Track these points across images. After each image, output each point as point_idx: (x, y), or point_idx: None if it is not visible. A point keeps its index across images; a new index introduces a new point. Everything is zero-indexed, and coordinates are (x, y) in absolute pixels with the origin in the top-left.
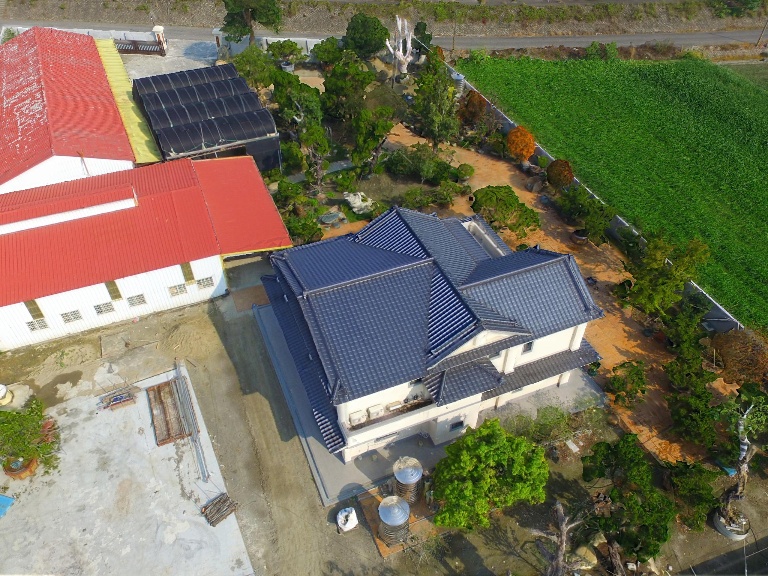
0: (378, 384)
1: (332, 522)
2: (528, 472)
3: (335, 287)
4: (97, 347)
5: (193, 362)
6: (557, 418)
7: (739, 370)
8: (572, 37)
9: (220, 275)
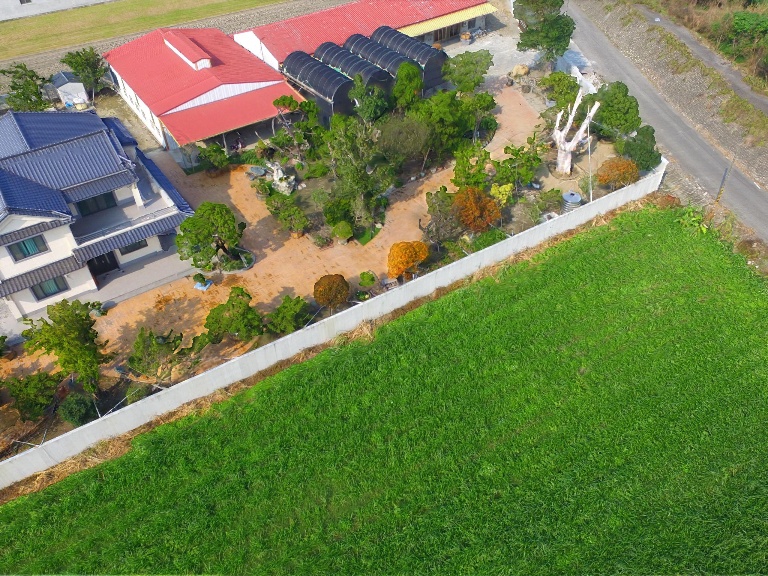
0: None
1: None
2: None
3: None
4: None
5: None
6: None
7: None
8: None
9: None
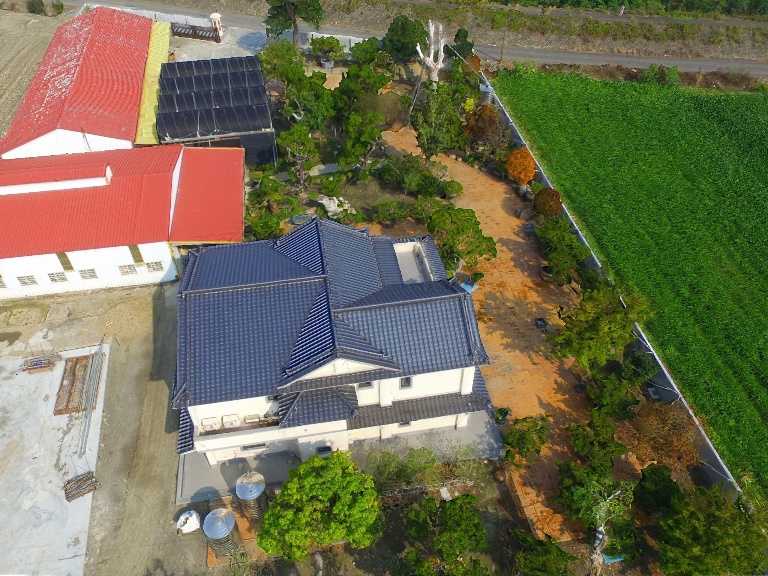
0: (223, 394)
1: (176, 521)
2: (348, 513)
3: (216, 290)
4: (45, 312)
5: (119, 341)
6: (427, 462)
7: (653, 448)
8: (636, 57)
9: (169, 261)
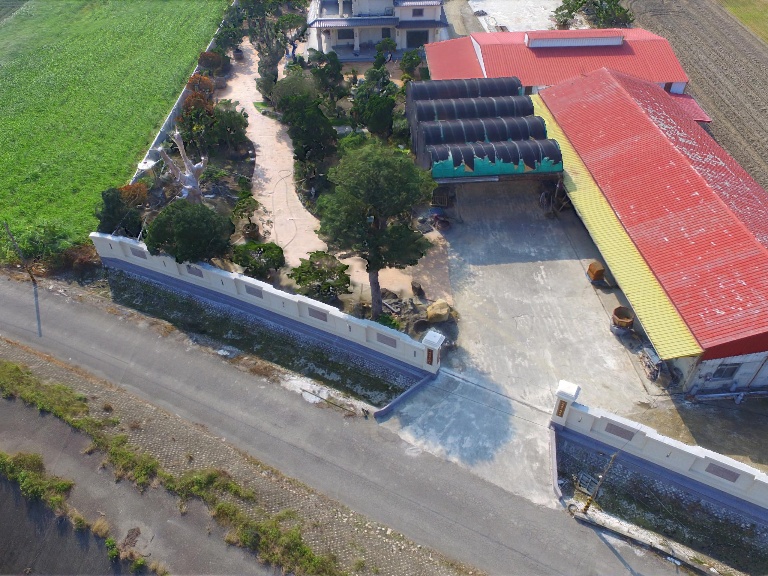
0: None
1: None
2: None
3: None
4: None
5: None
6: None
7: None
8: None
9: None
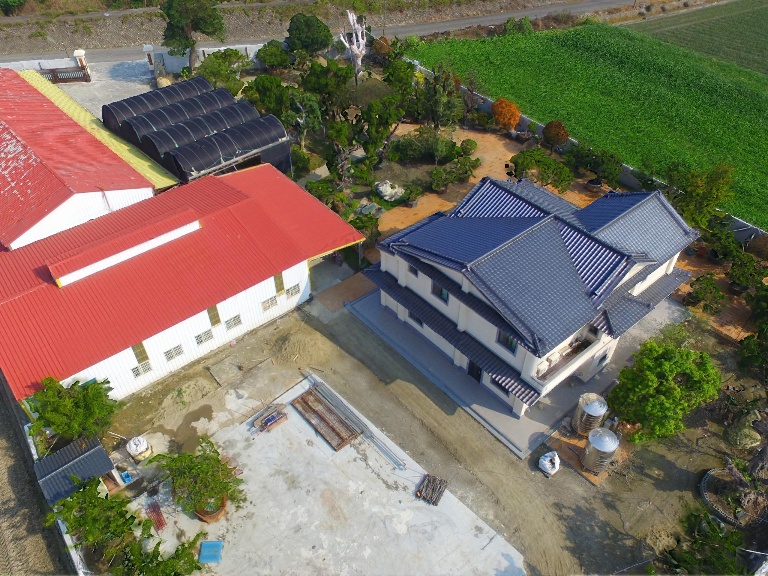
0: (566, 331)
1: (536, 471)
2: (706, 374)
3: (489, 255)
4: (208, 378)
5: (318, 368)
6: None
7: None
8: (482, 16)
9: (306, 280)
